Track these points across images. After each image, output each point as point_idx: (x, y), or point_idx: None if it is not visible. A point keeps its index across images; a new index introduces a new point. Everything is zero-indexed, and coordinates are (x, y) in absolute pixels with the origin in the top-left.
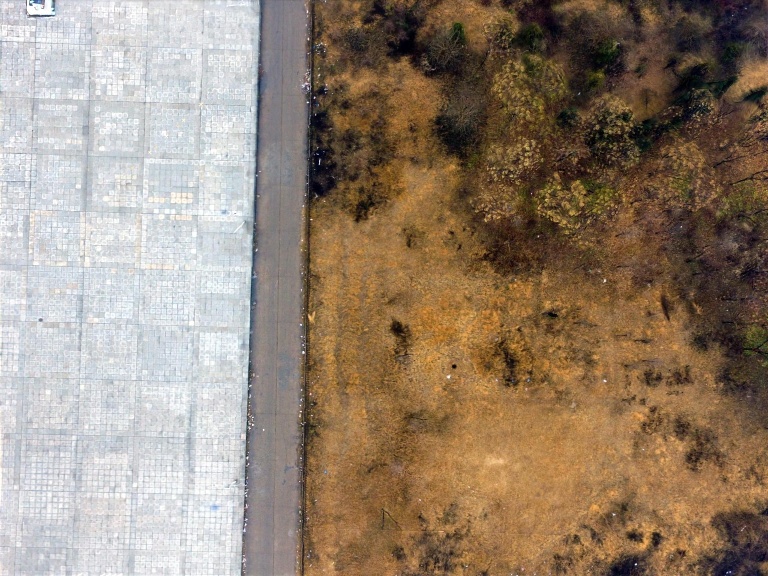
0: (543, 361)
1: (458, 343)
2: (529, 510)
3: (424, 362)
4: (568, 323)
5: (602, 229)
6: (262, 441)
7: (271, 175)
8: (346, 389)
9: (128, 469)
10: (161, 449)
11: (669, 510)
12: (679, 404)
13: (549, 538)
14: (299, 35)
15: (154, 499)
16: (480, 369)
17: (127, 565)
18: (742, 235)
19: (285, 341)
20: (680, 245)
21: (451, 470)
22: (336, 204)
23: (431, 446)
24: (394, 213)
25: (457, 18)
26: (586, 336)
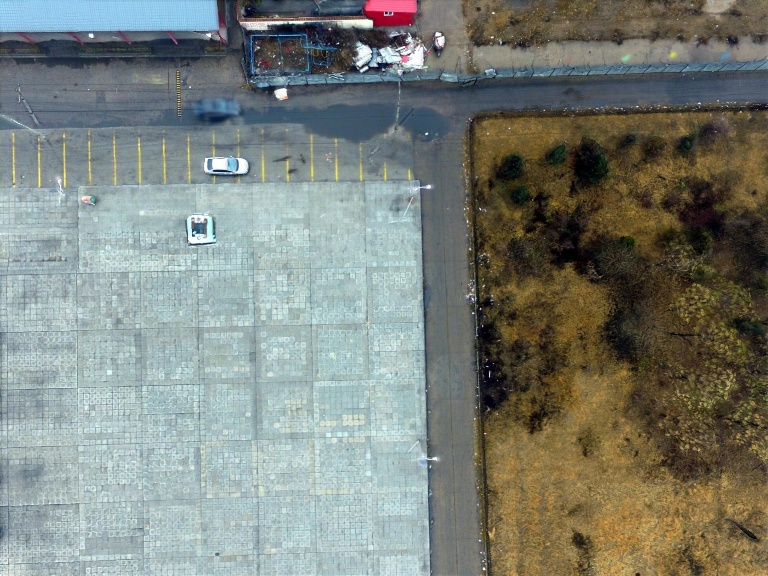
0: (728, 566)
1: (641, 552)
2: None
3: (608, 573)
4: (750, 525)
5: None
6: None
7: (440, 389)
8: None
9: None
10: None
11: None
12: None
13: None
14: (460, 245)
15: None
16: None
17: None
18: None
19: (465, 558)
20: None
21: None
22: (509, 416)
23: None
24: (568, 422)
25: (619, 222)
26: None
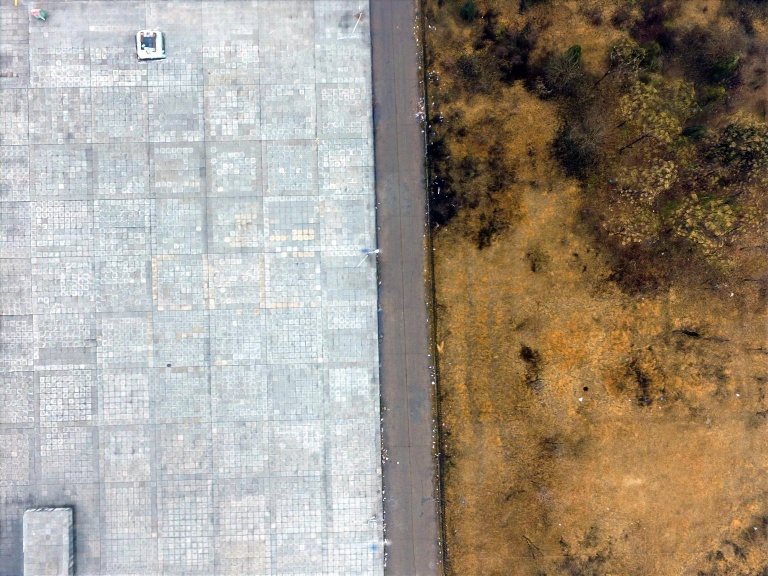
0: (675, 379)
1: (589, 365)
2: (670, 529)
3: (556, 386)
4: (698, 339)
5: None
6: (397, 474)
7: (390, 206)
8: (479, 418)
9: (265, 510)
10: (297, 488)
11: None
12: None
13: (692, 556)
14: (410, 64)
15: (293, 539)
16: (612, 390)
17: None
18: None
19: (414, 373)
20: None
21: (589, 493)
22: (458, 232)
23: (568, 470)
24: (517, 238)
25: (569, 39)
26: (717, 351)
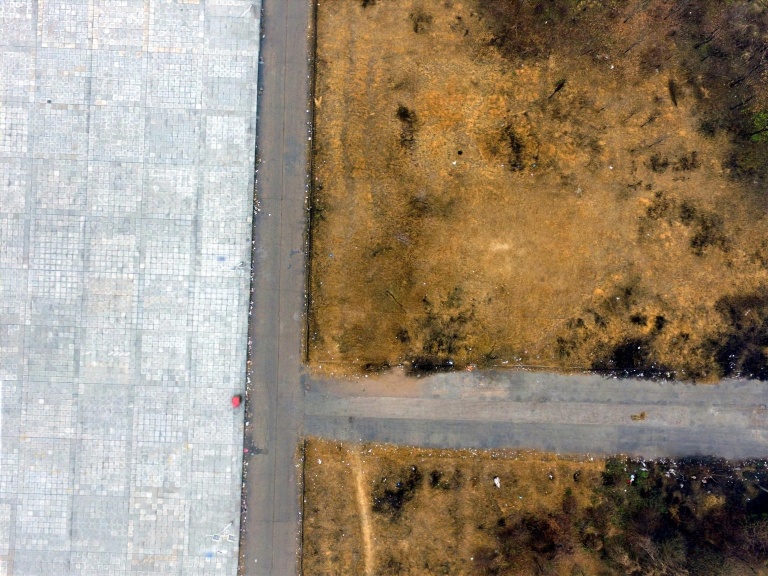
0: (549, 146)
1: (464, 128)
2: (533, 294)
3: (430, 147)
4: (575, 109)
5: (610, 14)
6: (268, 226)
7: None
8: (352, 173)
9: (135, 250)
10: (168, 231)
11: (673, 294)
12: (685, 189)
13: (553, 322)
14: None
15: (161, 280)
16: (486, 154)
17: (134, 344)
18: (752, 19)
19: (291, 127)
20: (689, 31)
21: (456, 254)
22: None
23: (436, 230)
24: None
25: None
26: (593, 122)
